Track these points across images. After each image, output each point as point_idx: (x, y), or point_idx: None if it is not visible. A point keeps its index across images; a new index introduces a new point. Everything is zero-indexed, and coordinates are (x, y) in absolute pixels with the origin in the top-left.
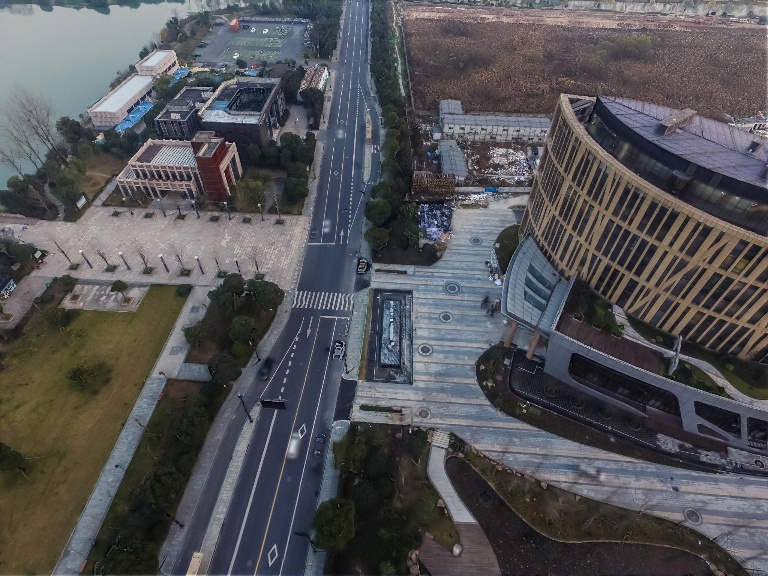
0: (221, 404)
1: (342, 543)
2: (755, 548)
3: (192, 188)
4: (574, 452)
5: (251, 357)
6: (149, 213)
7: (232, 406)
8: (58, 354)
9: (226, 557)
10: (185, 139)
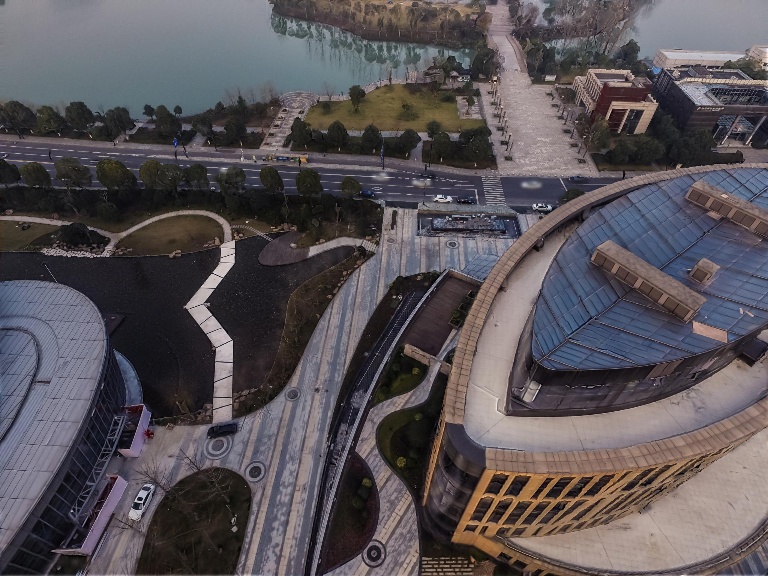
0: (394, 157)
1: (297, 182)
2: (259, 434)
3: (590, 108)
4: (356, 324)
5: (431, 163)
6: (557, 105)
7: (394, 161)
8: (424, 104)
9: None
10: None
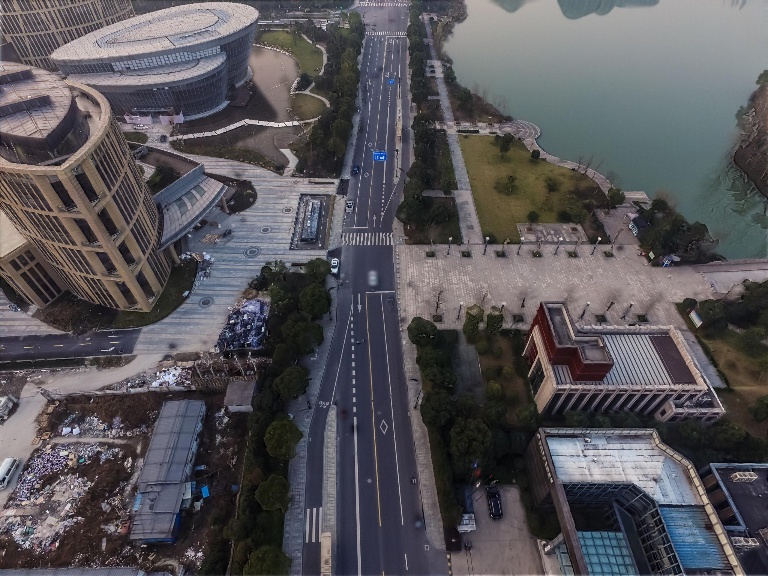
0: None
1: None
2: None
3: None
4: (217, 170)
5: None
6: (604, 321)
7: None
8: None
9: (390, 143)
10: (686, 453)
